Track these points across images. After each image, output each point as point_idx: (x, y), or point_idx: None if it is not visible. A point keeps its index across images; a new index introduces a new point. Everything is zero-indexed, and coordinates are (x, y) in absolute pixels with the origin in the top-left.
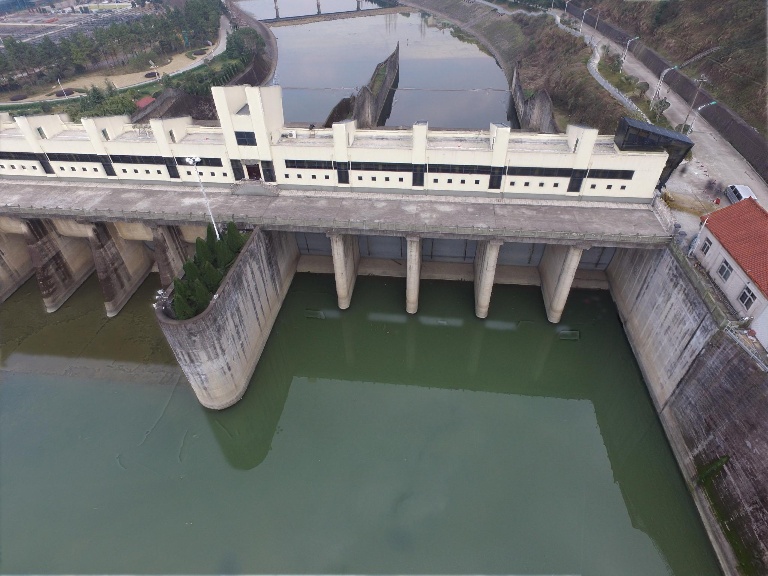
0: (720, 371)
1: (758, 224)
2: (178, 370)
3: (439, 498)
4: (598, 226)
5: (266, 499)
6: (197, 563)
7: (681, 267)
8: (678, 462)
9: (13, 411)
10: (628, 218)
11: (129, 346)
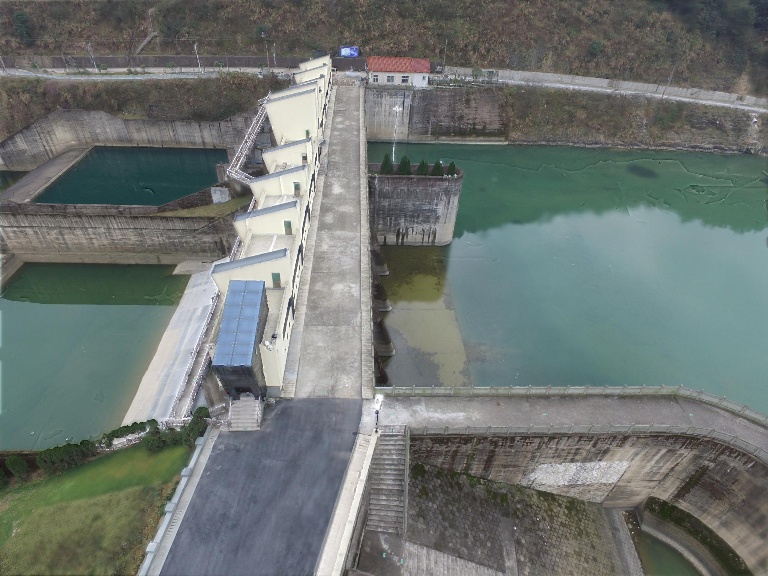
0: (420, 102)
1: (383, 60)
2: (430, 258)
3: (463, 182)
4: (352, 95)
5: (486, 219)
6: (520, 229)
7: (380, 89)
8: (427, 143)
9: (490, 323)
10: (344, 90)
11: (418, 287)
